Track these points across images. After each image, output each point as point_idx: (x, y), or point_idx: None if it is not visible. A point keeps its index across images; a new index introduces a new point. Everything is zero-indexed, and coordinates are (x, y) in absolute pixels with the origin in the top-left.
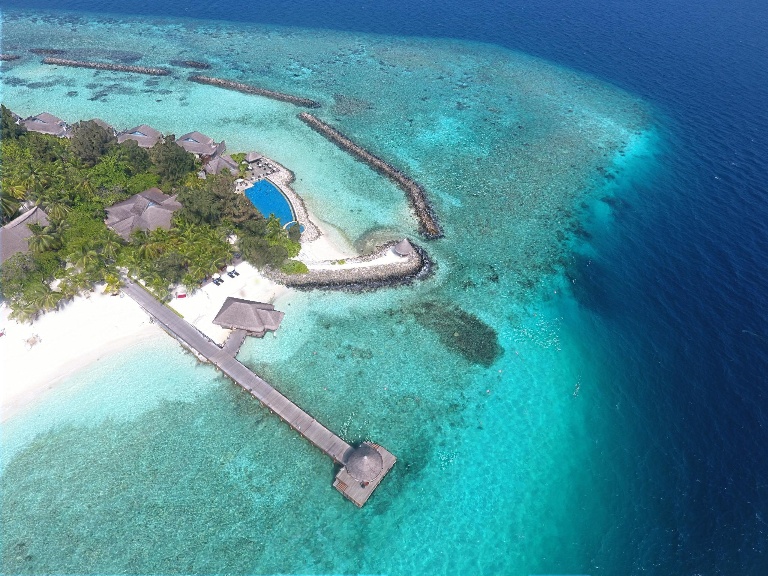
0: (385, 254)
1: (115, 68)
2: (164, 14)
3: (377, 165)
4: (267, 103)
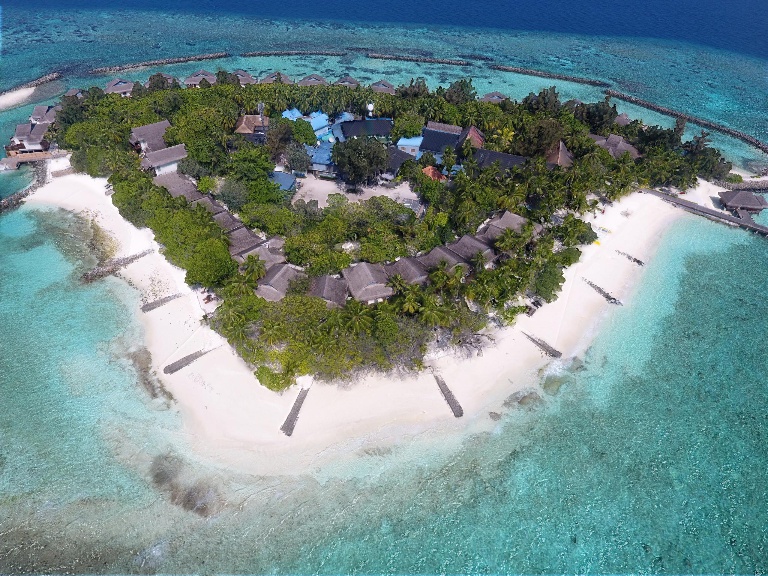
0: None
1: (428, 61)
2: (404, 21)
3: (702, 123)
4: (569, 84)
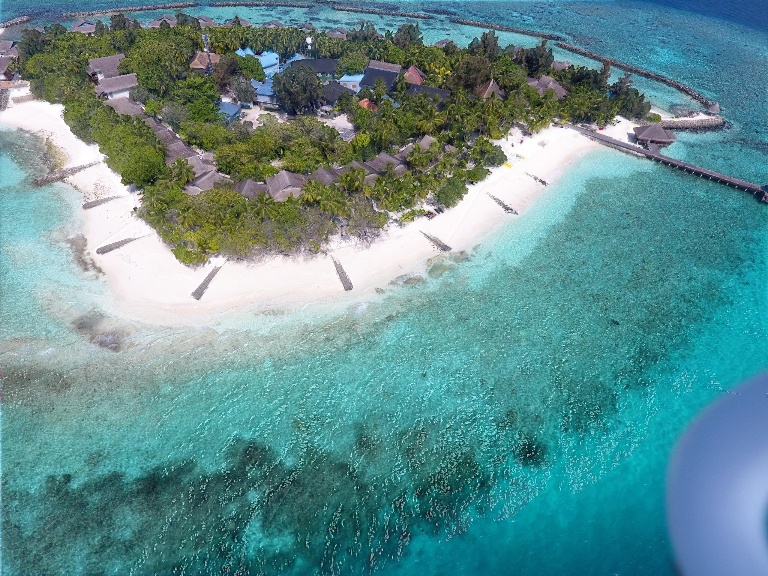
0: (699, 114)
1: (392, 14)
2: None
3: (643, 73)
4: (525, 37)
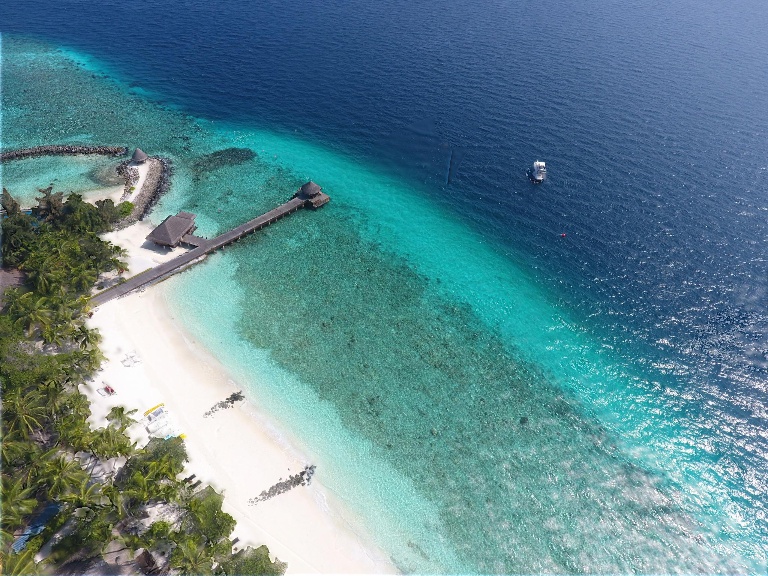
0: (136, 169)
1: None
2: None
3: None
4: None
